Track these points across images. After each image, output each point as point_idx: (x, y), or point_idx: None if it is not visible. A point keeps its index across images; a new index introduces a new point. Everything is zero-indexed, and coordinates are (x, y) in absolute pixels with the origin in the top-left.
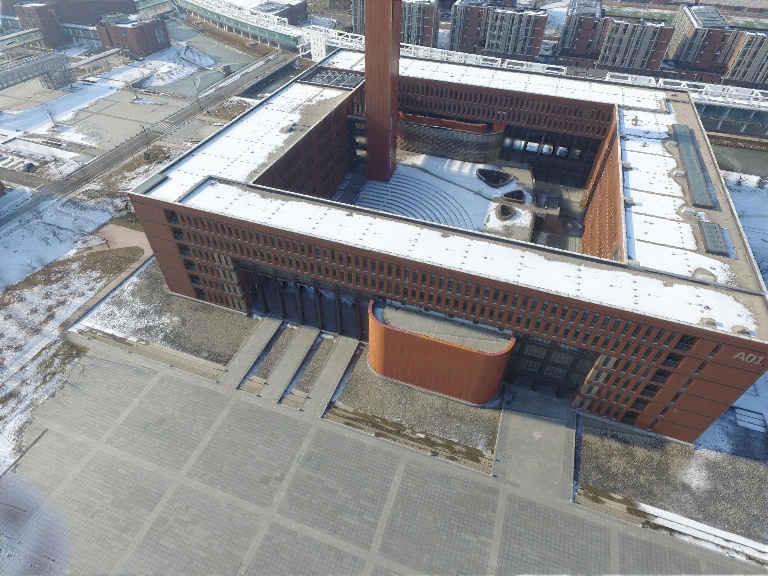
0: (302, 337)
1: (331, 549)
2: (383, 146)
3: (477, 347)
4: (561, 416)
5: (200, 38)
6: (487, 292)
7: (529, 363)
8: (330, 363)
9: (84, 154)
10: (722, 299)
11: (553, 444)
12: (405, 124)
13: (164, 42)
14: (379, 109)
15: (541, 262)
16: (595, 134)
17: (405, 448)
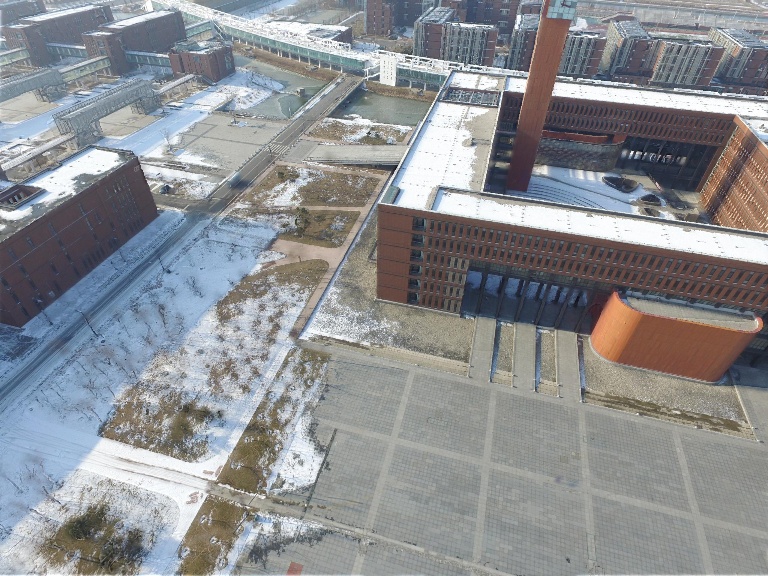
0: (523, 333)
1: (658, 514)
2: (529, 158)
3: (729, 327)
4: None
5: (256, 63)
6: (749, 276)
7: (758, 341)
8: (562, 354)
9: (211, 175)
10: None
11: None
12: None
13: (231, 68)
14: (533, 124)
15: None
16: (713, 142)
17: (671, 423)
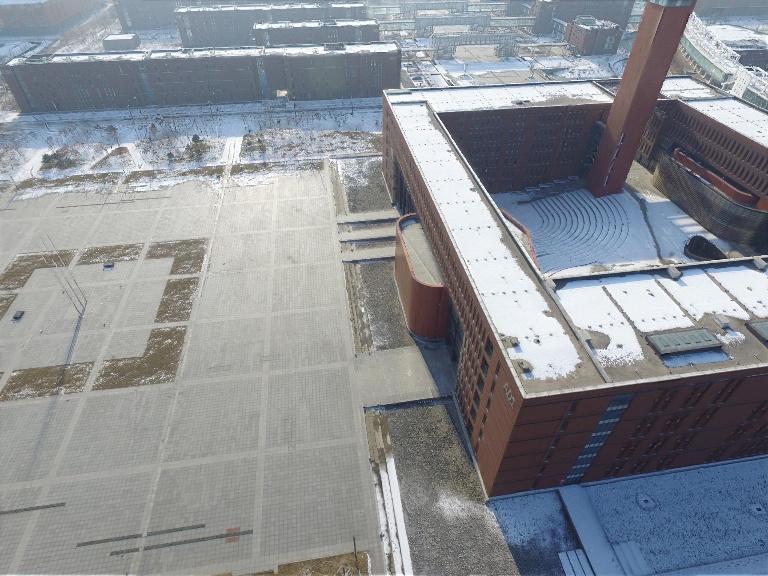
0: None
1: (265, 297)
2: (606, 159)
3: (420, 273)
4: (440, 384)
5: None
6: None
7: None
8: (385, 249)
9: None
10: (566, 352)
11: (408, 384)
12: (668, 160)
13: (611, 49)
14: (617, 121)
15: (493, 237)
16: None
17: (347, 304)
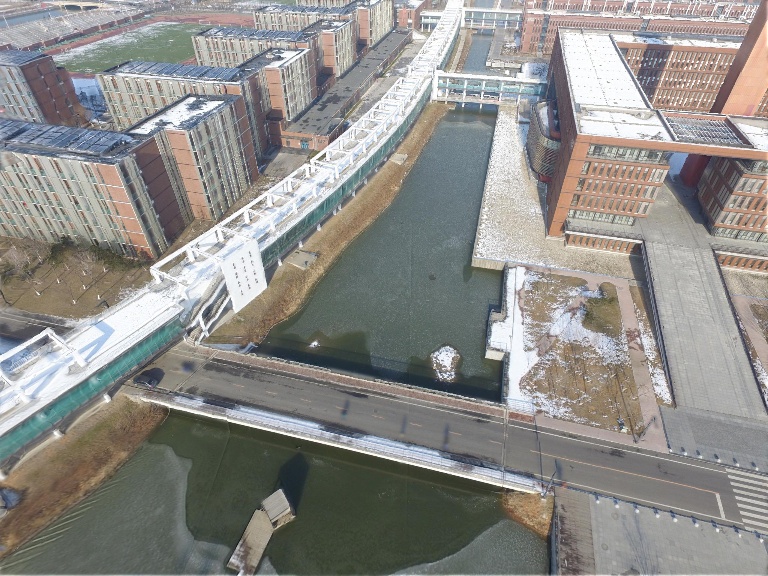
0: None
1: None
2: None
3: None
4: None
5: None
6: None
7: None
8: None
9: None
10: None
11: None
12: None
13: None
14: None
15: None
16: None
17: None
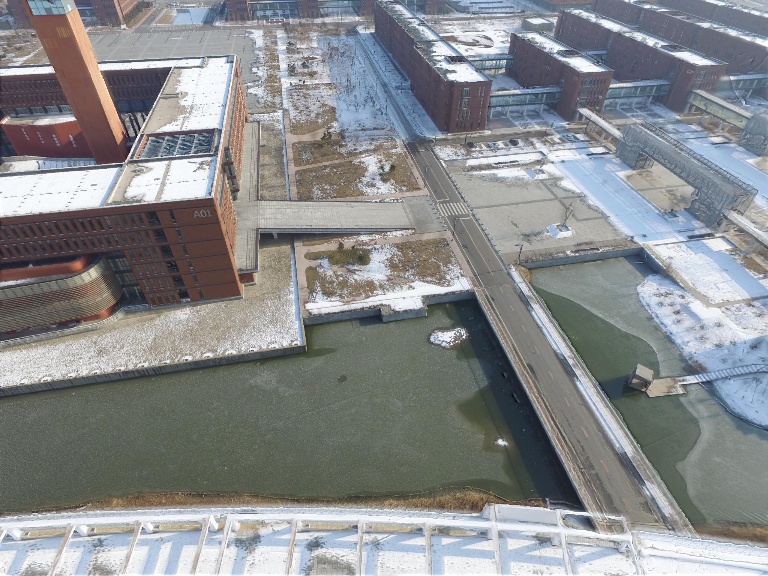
0: None
1: None
2: None
3: None
4: None
5: None
6: None
7: None
8: None
9: None
10: None
11: None
12: None
13: None
14: None
15: None
16: None
17: None
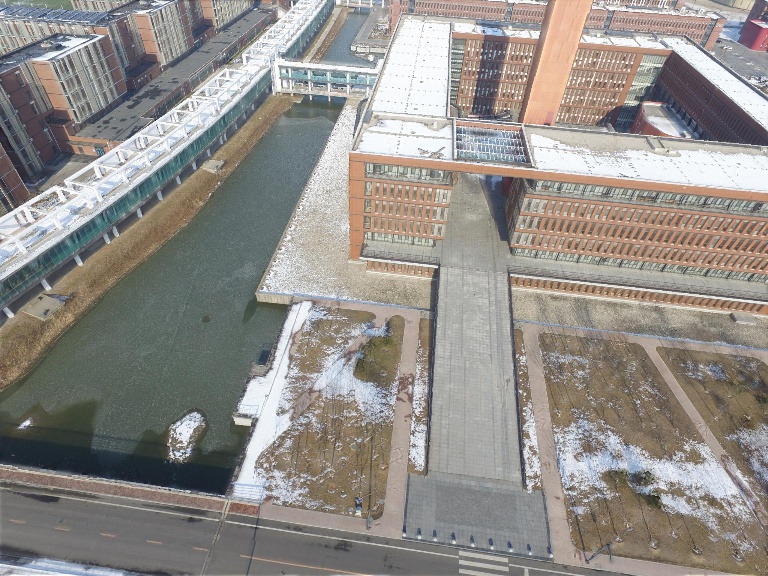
0: None
1: None
2: None
3: None
4: None
5: None
6: None
7: None
8: None
9: None
10: (666, 40)
11: None
12: None
13: None
14: None
15: None
16: None
17: None
